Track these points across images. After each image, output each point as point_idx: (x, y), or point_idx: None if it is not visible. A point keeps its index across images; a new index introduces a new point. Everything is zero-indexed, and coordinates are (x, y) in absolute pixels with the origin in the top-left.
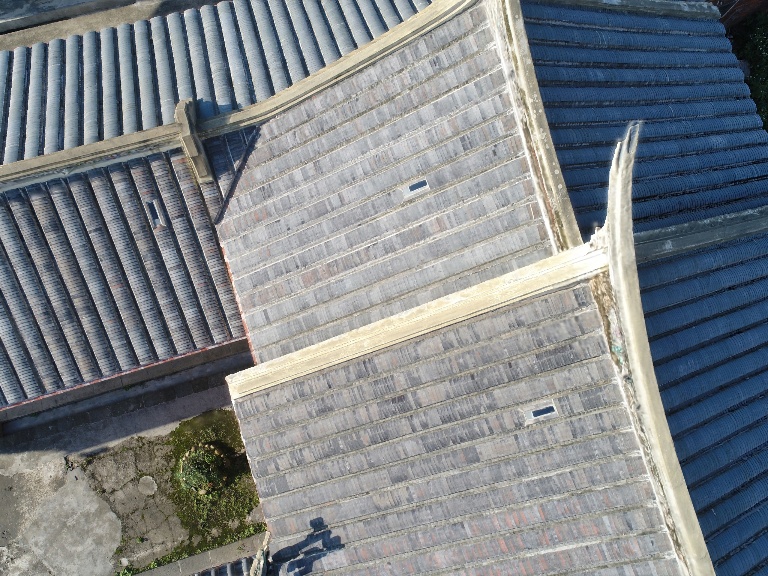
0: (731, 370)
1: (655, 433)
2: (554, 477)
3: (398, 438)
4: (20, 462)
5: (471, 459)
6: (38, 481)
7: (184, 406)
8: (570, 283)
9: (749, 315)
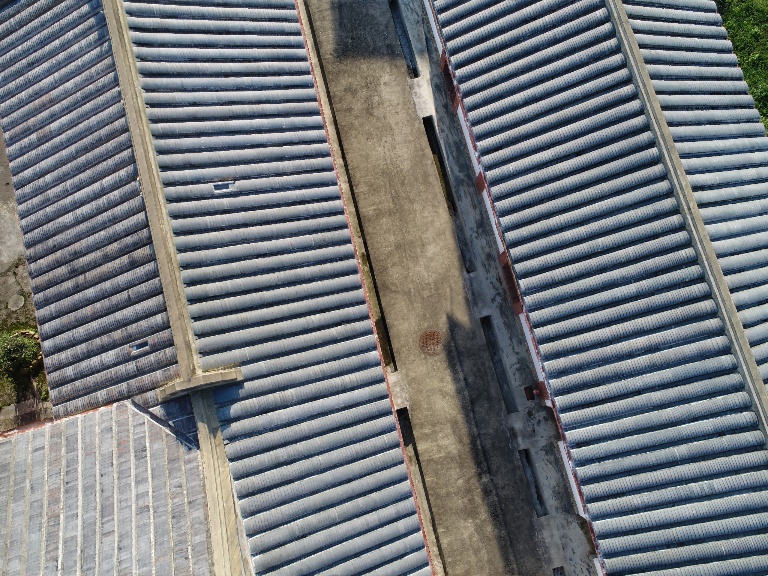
0: None
1: None
2: None
3: None
4: None
5: None
6: None
7: None
8: None
9: None
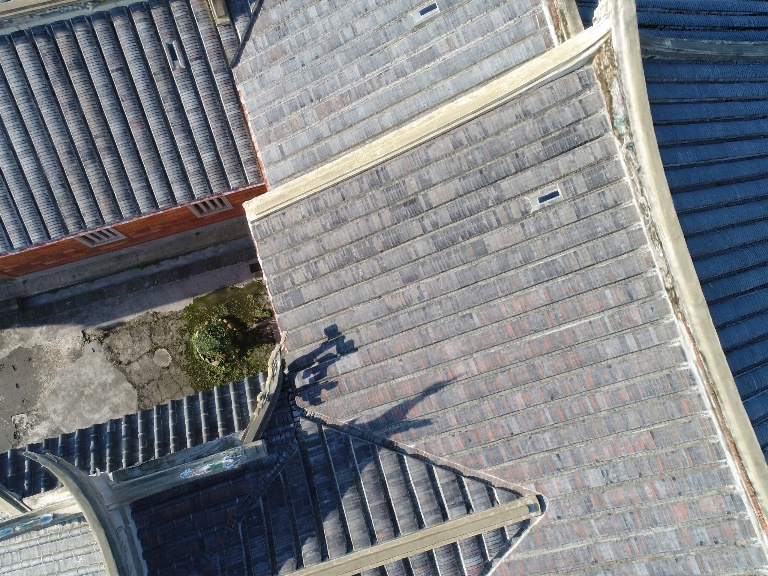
0: (728, 169)
1: (655, 190)
2: (559, 259)
3: (409, 241)
4: (39, 335)
5: (479, 252)
6: (56, 353)
7: (198, 283)
8: (574, 63)
9: (745, 126)
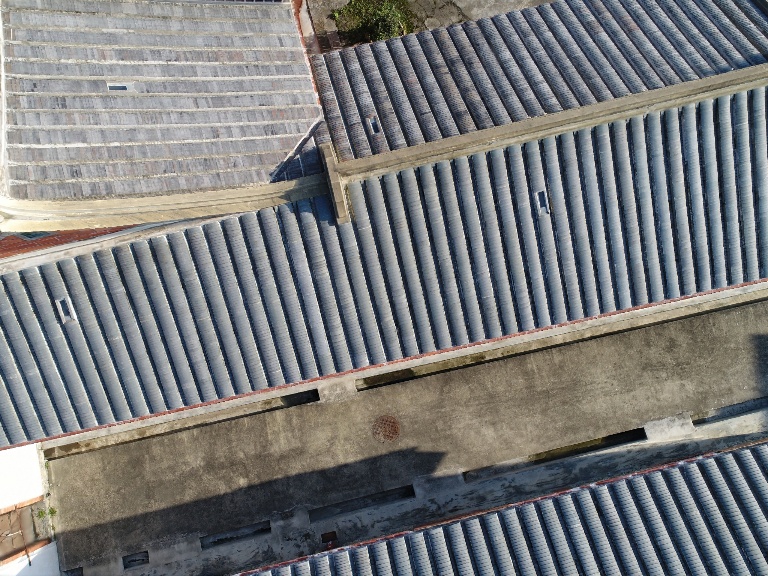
0: None
1: None
2: None
3: None
4: None
5: None
6: None
7: None
8: None
9: None
